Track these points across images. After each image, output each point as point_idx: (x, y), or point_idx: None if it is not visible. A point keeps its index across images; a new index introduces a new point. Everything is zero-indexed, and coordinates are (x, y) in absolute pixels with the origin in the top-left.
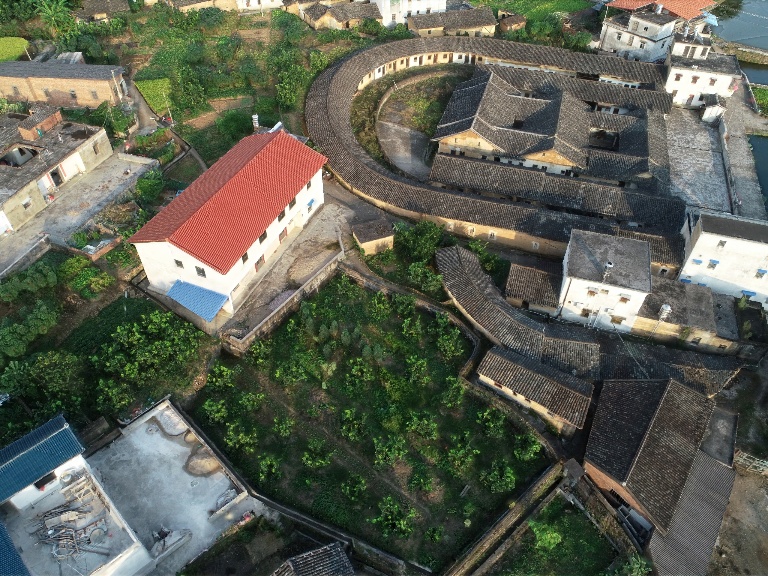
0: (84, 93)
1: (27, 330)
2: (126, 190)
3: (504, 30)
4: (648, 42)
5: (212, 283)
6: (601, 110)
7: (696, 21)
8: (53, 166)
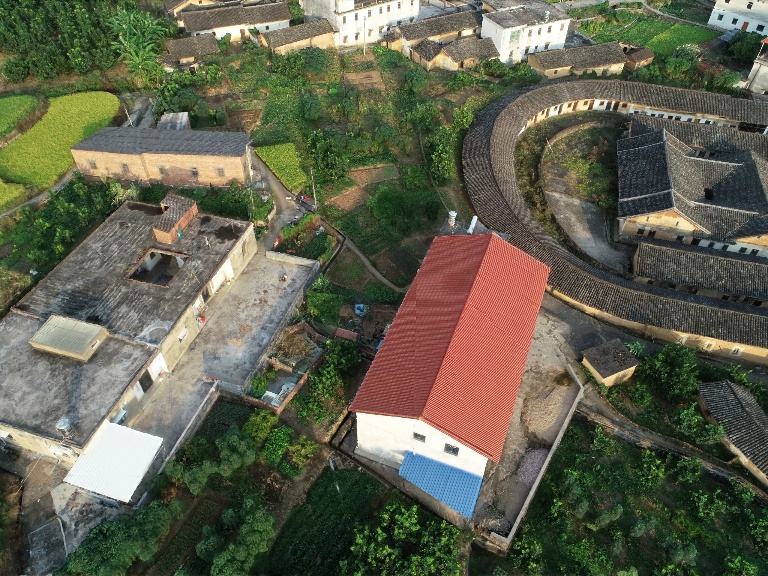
0: (208, 170)
1: (246, 552)
2: (293, 307)
3: (630, 66)
4: None
5: (463, 462)
6: None
7: None
8: (207, 282)
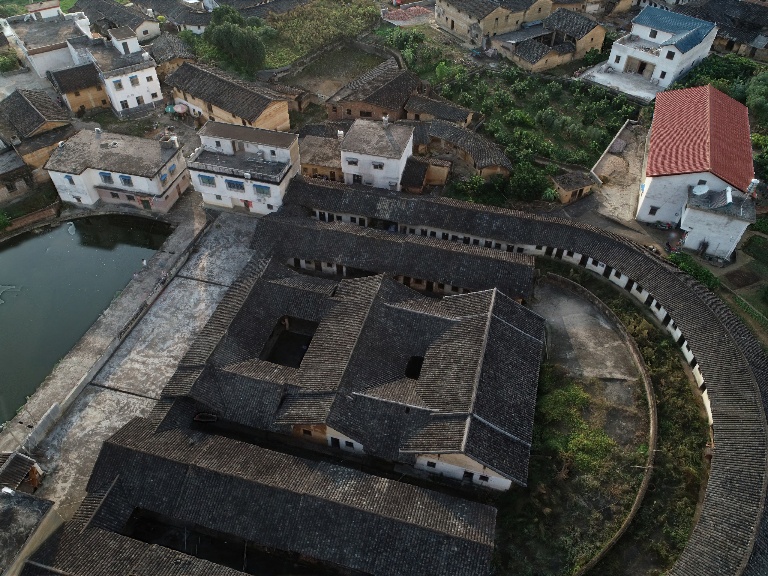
0: None
1: None
2: None
3: None
4: None
5: None
6: None
7: None
8: None
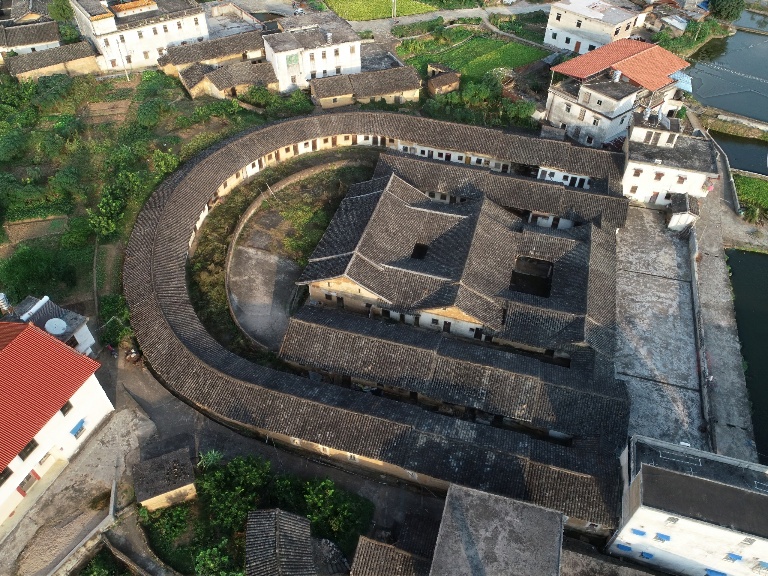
0: None
1: None
2: None
3: (432, 92)
4: (602, 119)
5: None
6: (537, 218)
7: (665, 87)
8: None
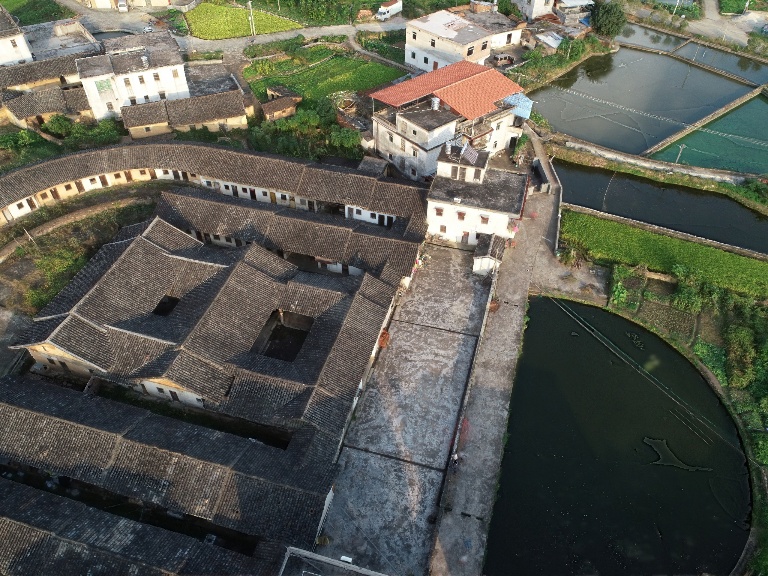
0: None
1: None
2: None
3: (265, 118)
4: (420, 150)
5: None
6: None
7: (497, 114)
8: None
